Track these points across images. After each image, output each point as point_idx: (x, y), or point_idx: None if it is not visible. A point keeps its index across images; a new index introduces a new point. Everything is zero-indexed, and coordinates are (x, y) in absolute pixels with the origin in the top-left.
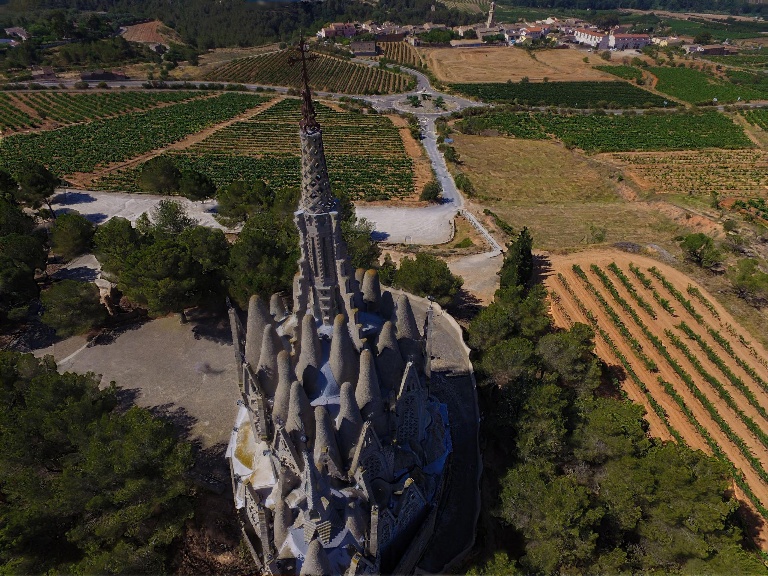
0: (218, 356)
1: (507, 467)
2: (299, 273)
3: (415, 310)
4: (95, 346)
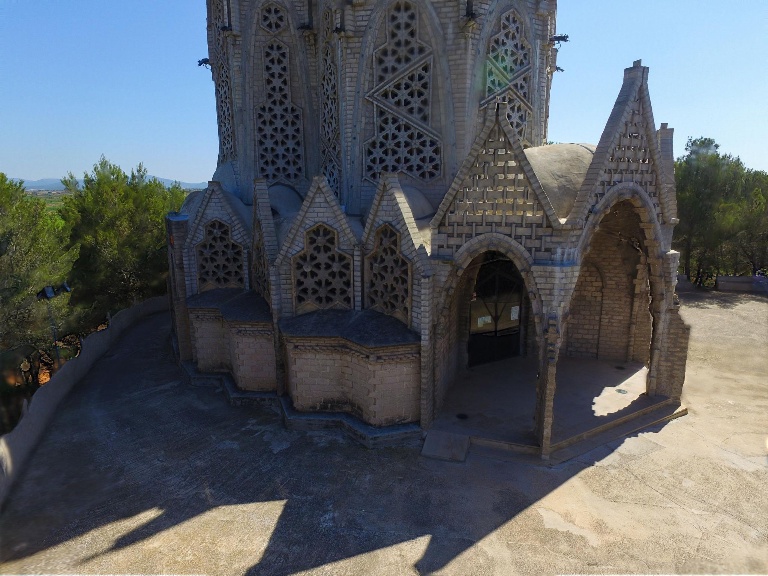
0: None
1: (28, 302)
2: None
3: None
4: None
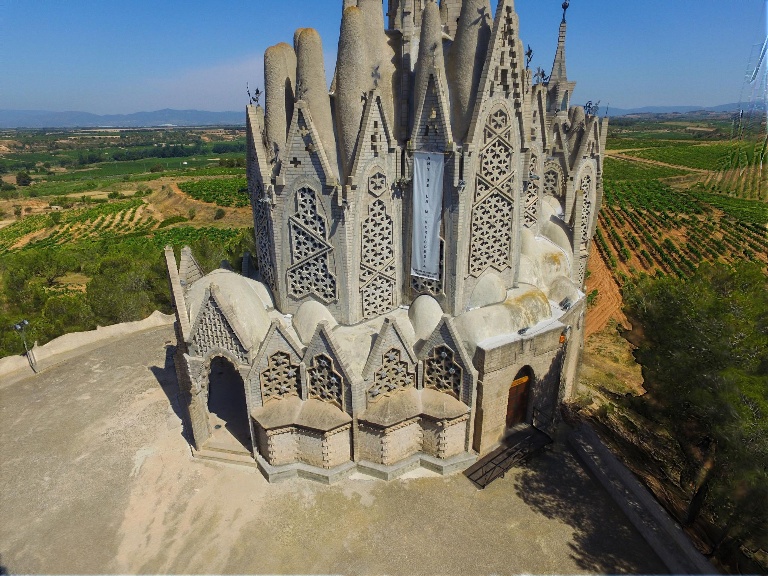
0: None
1: None
2: None
3: (1, 395)
4: None
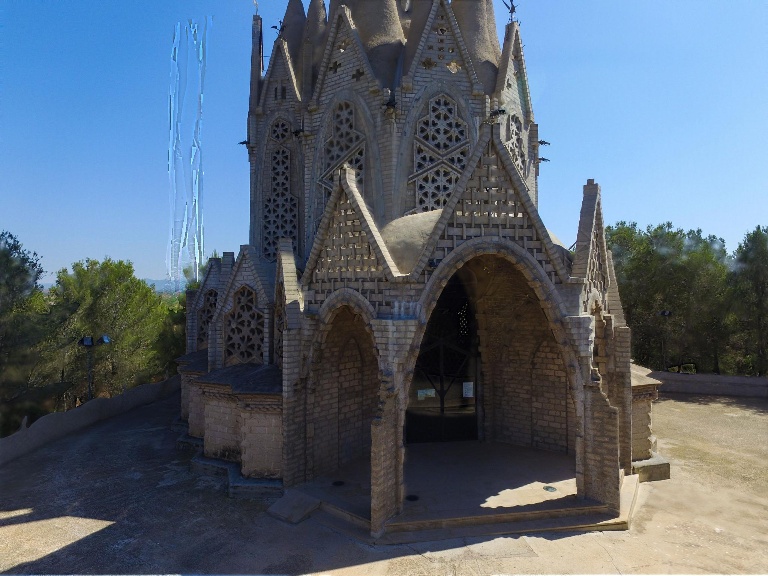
0: None
1: (105, 355)
2: None
3: None
4: None
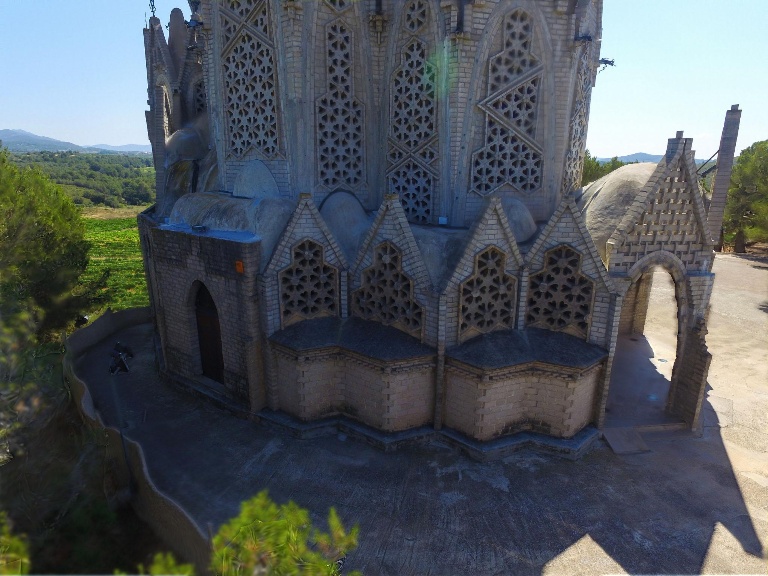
0: (722, 299)
1: None
2: None
3: None
4: (750, 265)
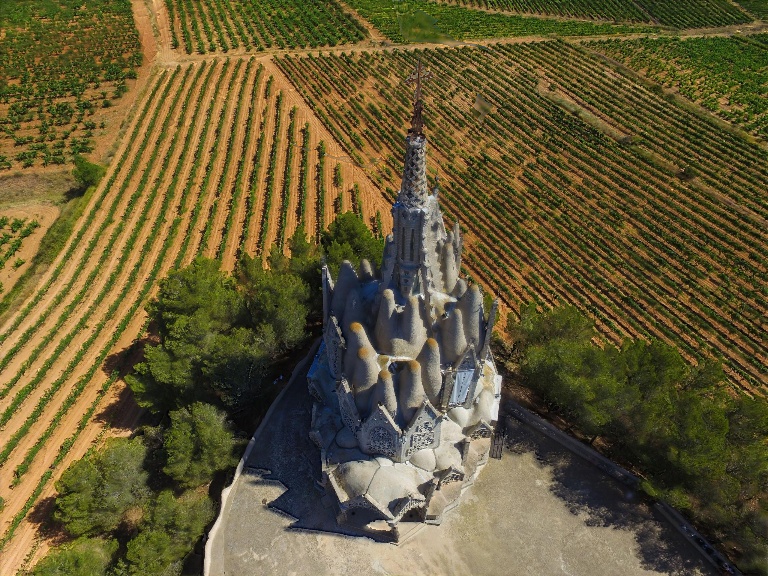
0: None
1: None
2: (433, 340)
3: None
4: None
